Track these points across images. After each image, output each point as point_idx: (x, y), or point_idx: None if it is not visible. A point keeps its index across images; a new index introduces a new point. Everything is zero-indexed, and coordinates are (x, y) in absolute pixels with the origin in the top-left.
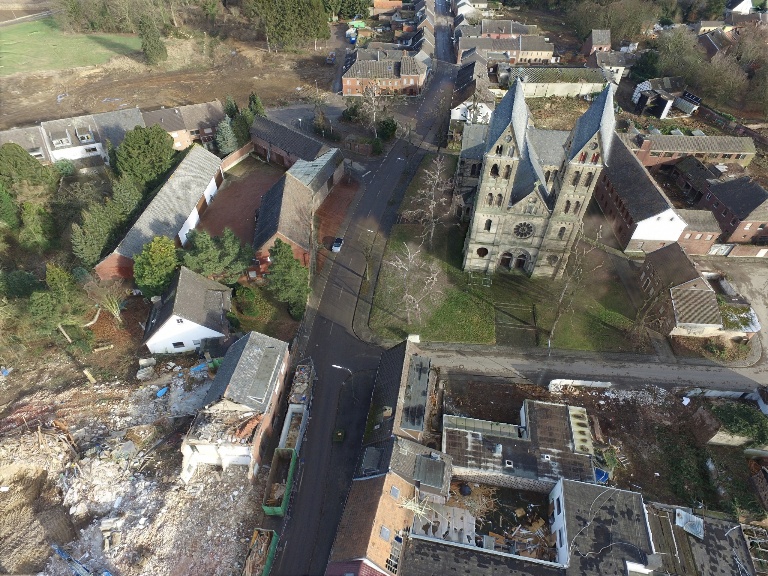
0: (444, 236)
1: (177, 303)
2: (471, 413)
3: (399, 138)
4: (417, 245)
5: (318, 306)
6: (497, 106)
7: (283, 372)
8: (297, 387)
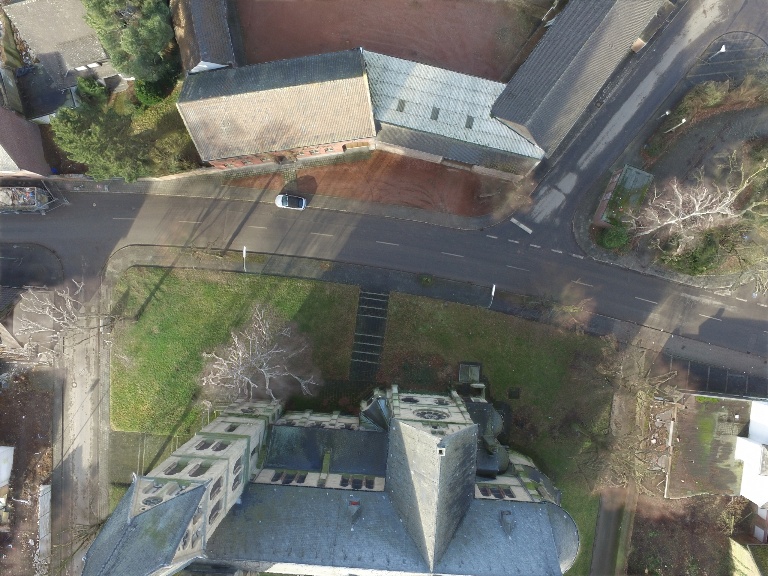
0: (320, 371)
1: (24, 5)
2: (7, 392)
3: (681, 282)
4: (297, 328)
5: (163, 194)
6: (120, 536)
7: (8, 173)
8: (6, 193)
